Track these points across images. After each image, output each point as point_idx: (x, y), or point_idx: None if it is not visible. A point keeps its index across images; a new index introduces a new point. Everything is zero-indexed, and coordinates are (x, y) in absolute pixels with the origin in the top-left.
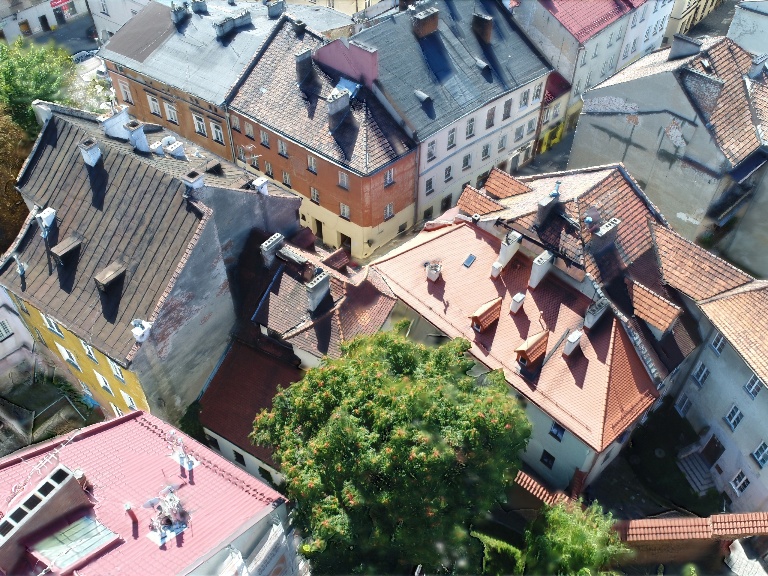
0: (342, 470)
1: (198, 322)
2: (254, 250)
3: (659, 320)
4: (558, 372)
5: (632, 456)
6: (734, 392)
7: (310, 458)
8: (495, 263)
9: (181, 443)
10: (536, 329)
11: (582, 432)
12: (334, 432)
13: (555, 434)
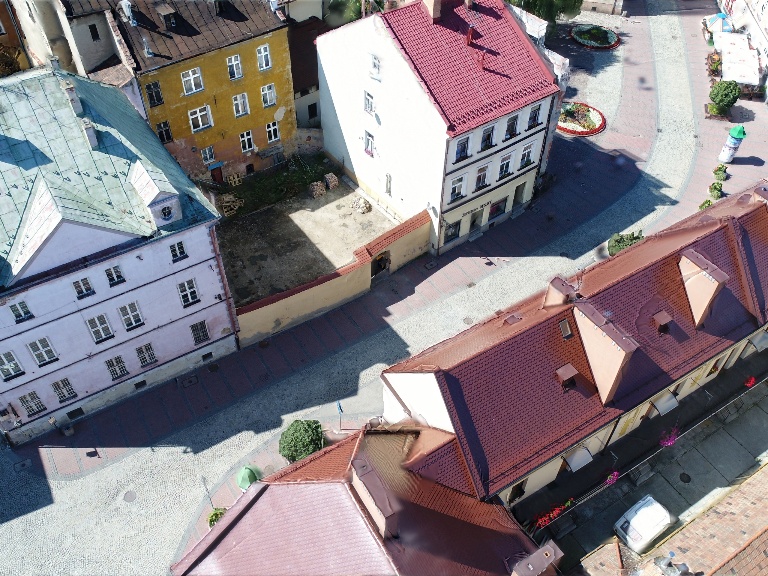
0: None
1: None
2: None
3: None
4: None
5: None
6: None
7: None
8: None
9: None
10: None
11: None
12: None
13: None
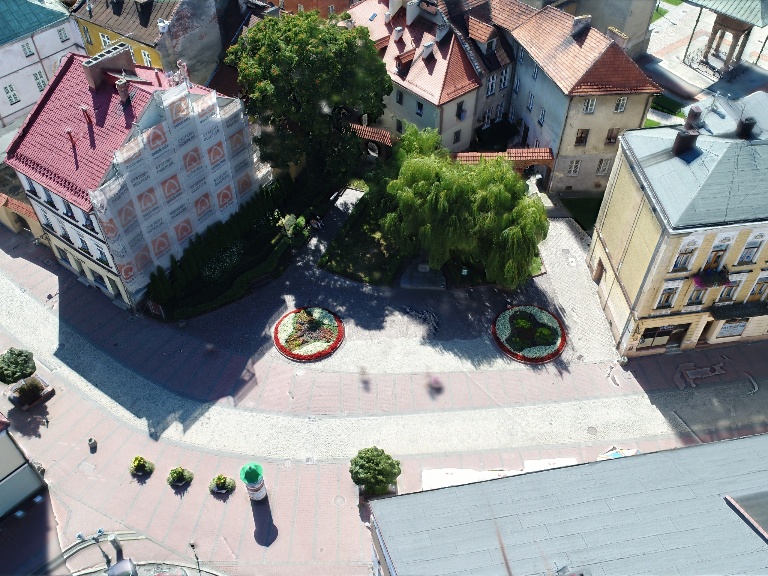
0: (271, 59)
1: (198, 37)
2: (234, 5)
3: (482, 37)
4: (419, 69)
5: (478, 147)
6: (529, 83)
7: (256, 64)
8: (387, 12)
9: None
10: (409, 48)
11: (429, 97)
12: (268, 40)
13: (419, 113)
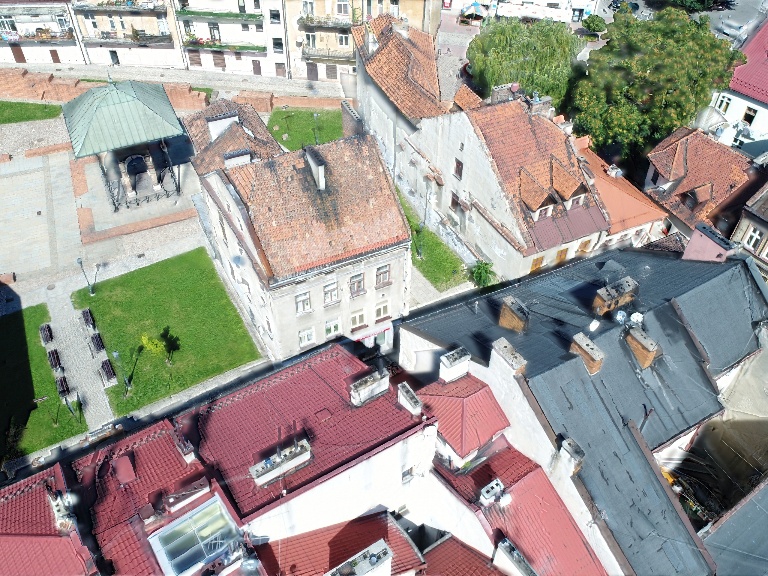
0: None
1: None
2: None
3: None
4: None
5: None
6: None
7: None
8: None
9: None
10: None
11: None
12: None
13: None
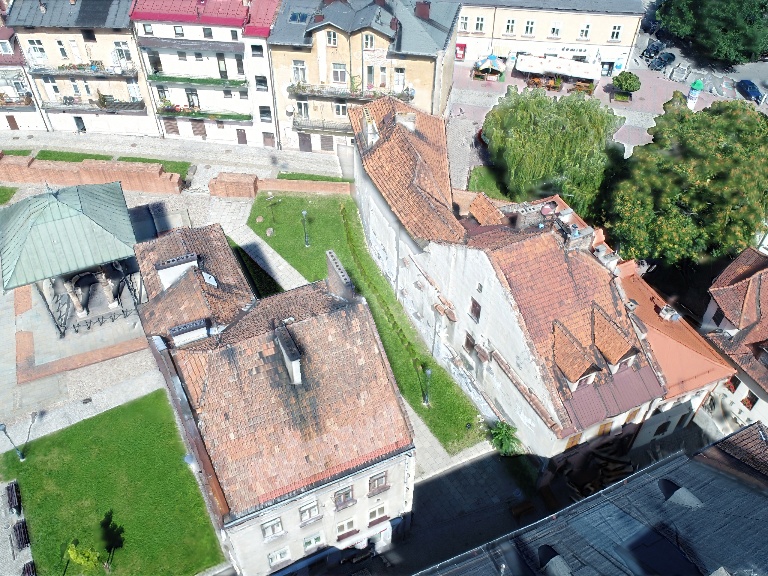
0: None
1: None
2: None
3: None
4: None
5: None
6: None
7: None
8: (618, 272)
9: None
10: None
11: None
12: None
13: None
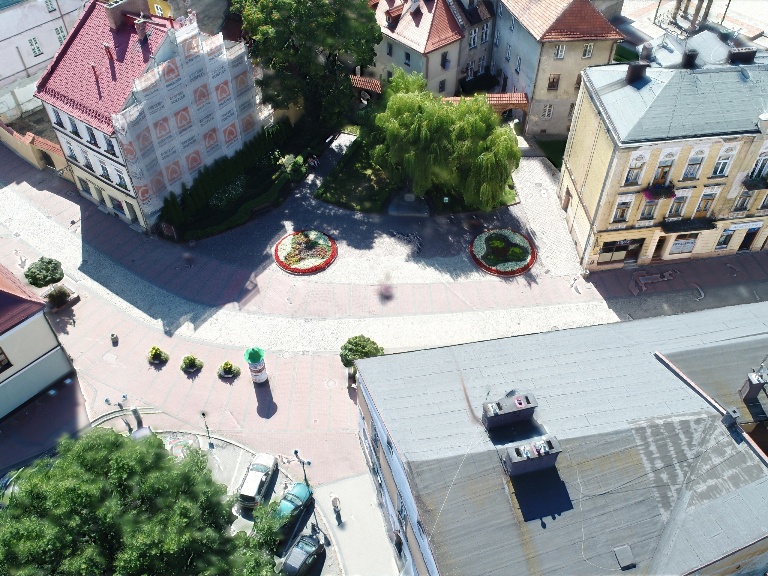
0: (272, 5)
1: None
2: None
3: None
4: (407, 22)
5: None
6: (507, 35)
7: (259, 11)
8: None
9: (195, 14)
10: (398, 4)
11: (416, 47)
12: None
13: (407, 63)
